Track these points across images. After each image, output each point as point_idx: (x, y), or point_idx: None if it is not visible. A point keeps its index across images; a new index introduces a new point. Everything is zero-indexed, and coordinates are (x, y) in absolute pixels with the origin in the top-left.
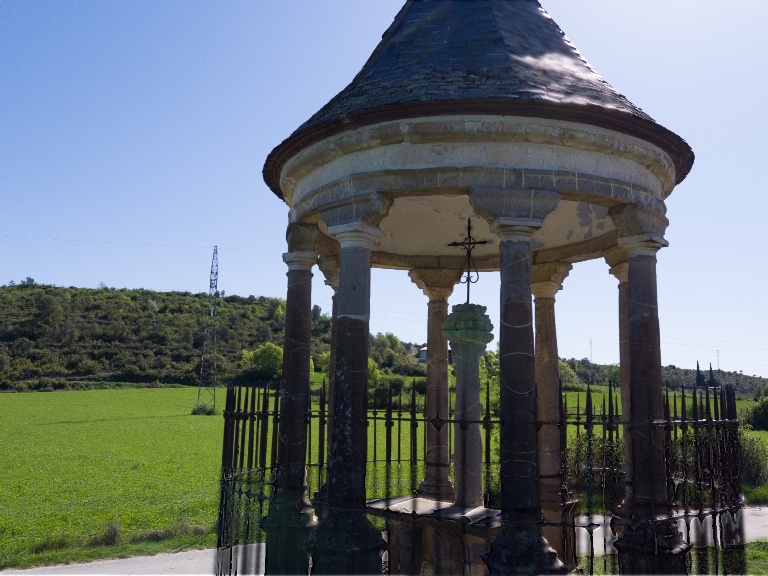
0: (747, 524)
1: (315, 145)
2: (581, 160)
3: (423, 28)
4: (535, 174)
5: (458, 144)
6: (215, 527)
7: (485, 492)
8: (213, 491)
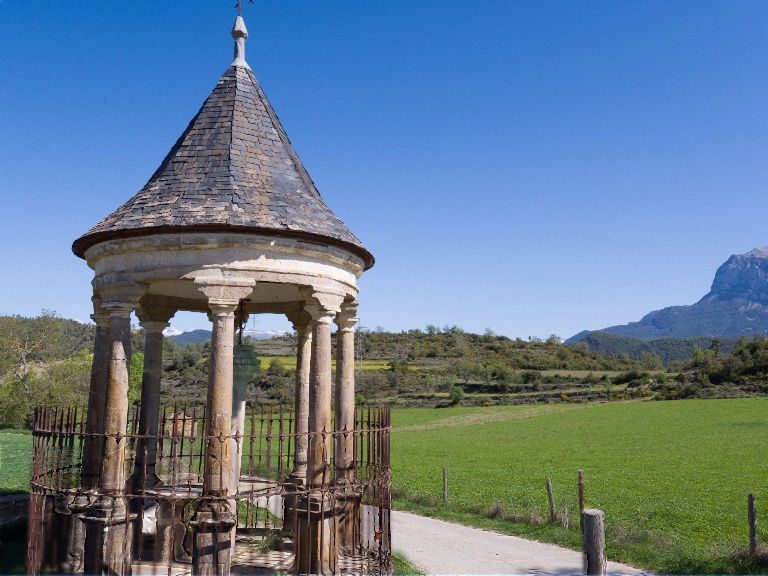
0: None
1: None
2: None
3: None
4: None
5: None
6: (548, 522)
7: None
8: None
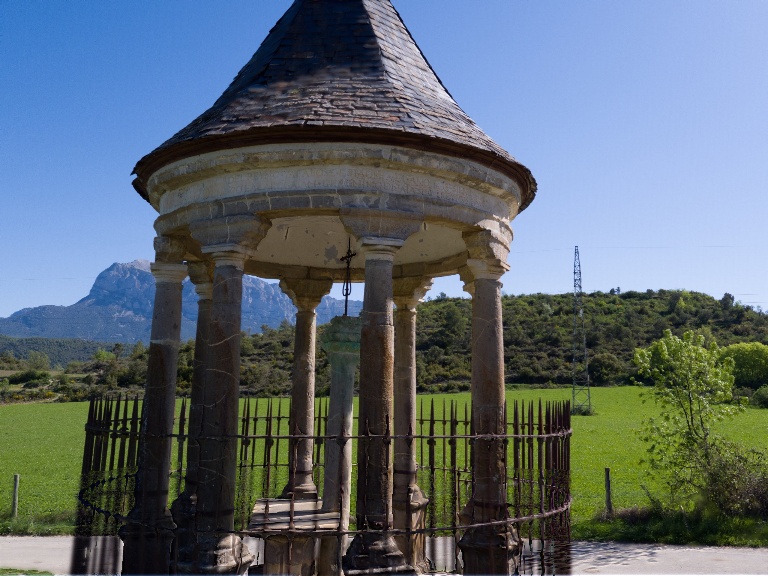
0: None
1: None
2: (278, 178)
3: (241, 75)
4: (232, 201)
5: (189, 185)
6: None
7: (642, 509)
8: (445, 488)
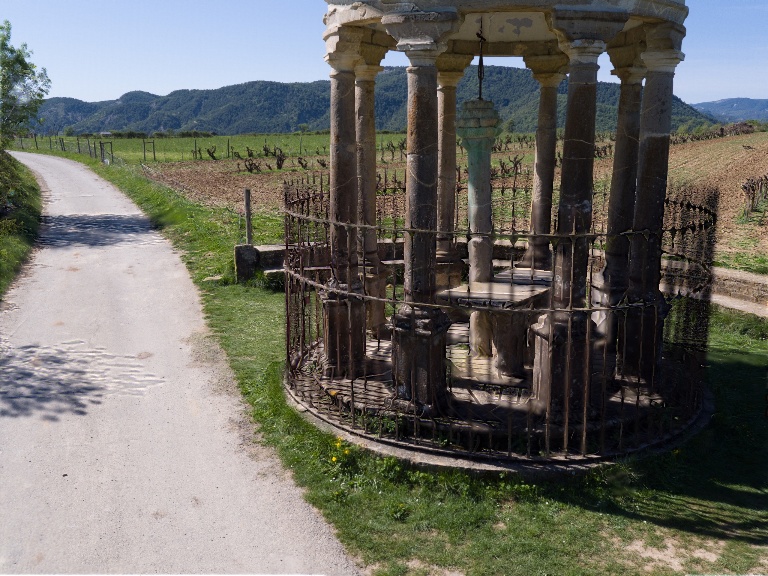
0: (116, 276)
1: None
2: None
3: None
4: None
5: None
6: None
7: None
8: None
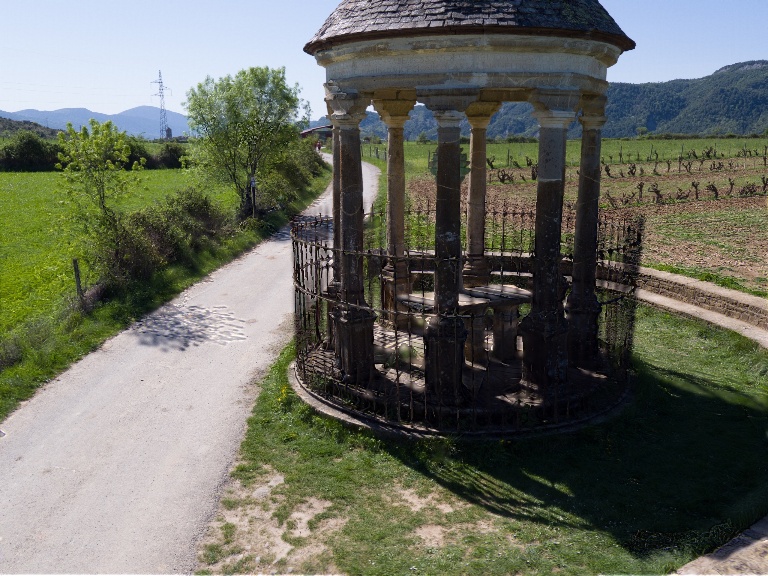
0: None
1: (552, 38)
2: None
3: None
4: None
5: None
6: None
7: (101, 287)
8: None
